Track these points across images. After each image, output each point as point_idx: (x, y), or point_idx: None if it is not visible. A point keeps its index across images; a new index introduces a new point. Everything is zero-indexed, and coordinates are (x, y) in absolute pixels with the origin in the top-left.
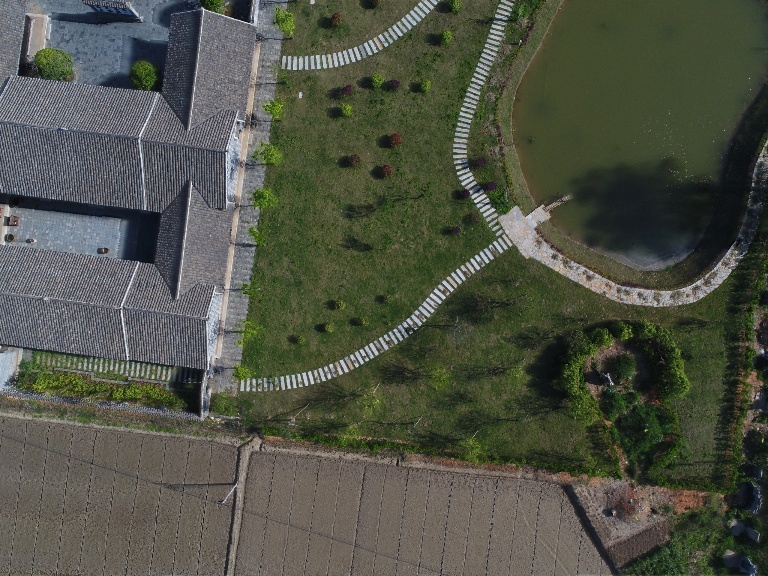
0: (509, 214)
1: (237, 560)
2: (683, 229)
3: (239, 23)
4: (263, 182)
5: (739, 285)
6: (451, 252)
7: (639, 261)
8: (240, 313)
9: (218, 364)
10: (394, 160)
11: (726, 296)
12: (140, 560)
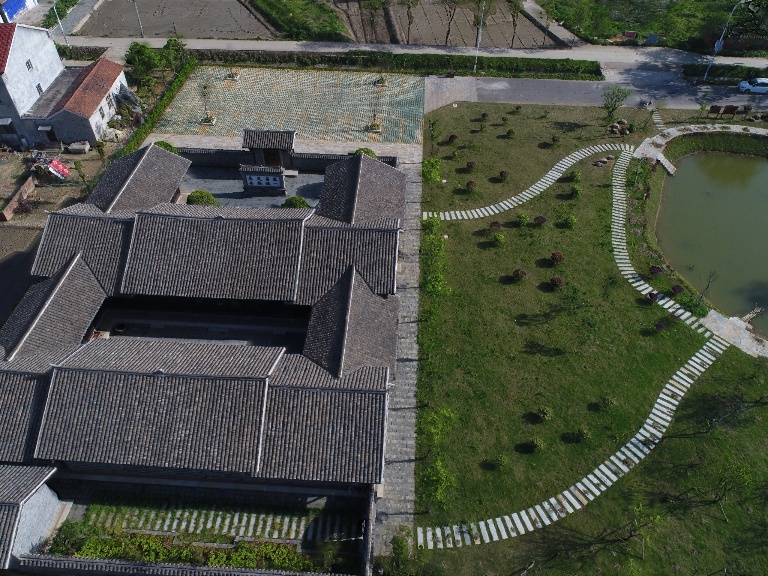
0: (709, 317)
1: None
2: None
3: (392, 169)
4: (418, 302)
5: None
6: (662, 353)
7: None
8: (406, 437)
9: (379, 509)
10: (560, 277)
11: None
12: None
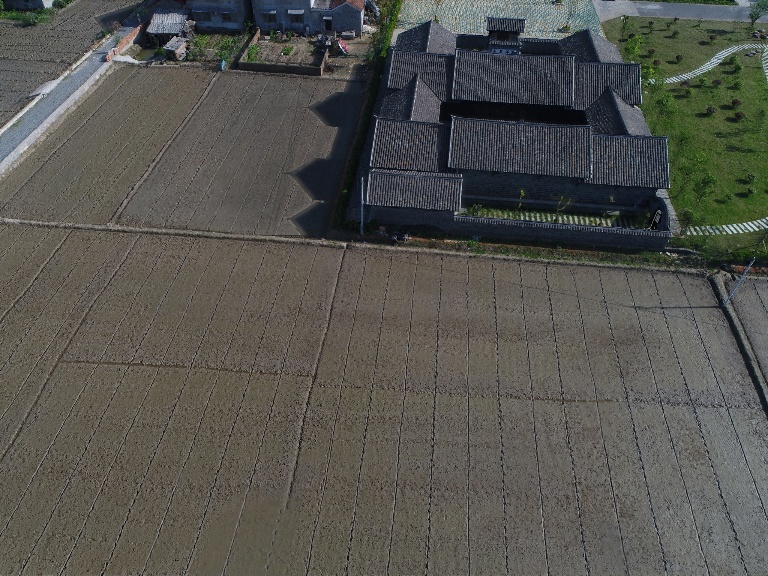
0: None
1: (767, 379)
2: None
3: None
4: None
5: None
6: None
7: None
8: None
9: None
10: None
11: None
12: (640, 381)
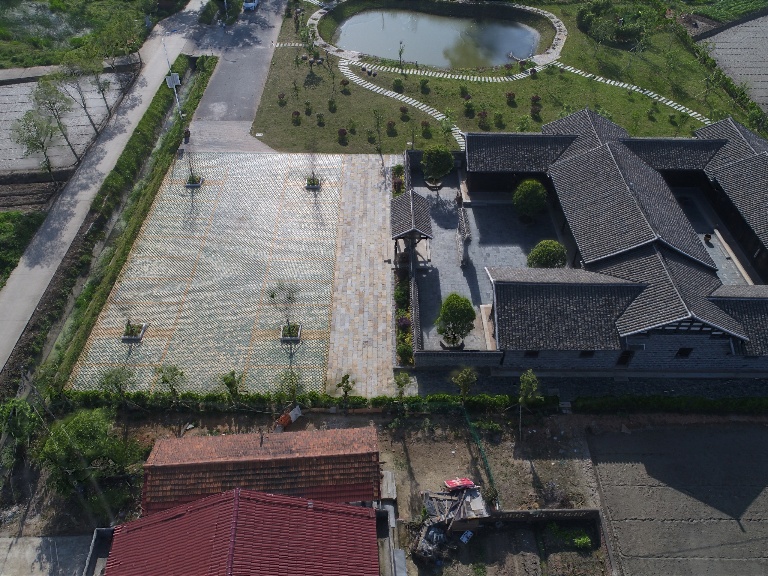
0: None
1: None
2: (507, 26)
3: None
4: None
5: (534, 3)
6: (576, 78)
7: (535, 35)
8: None
9: None
10: None
11: (543, 6)
12: None
